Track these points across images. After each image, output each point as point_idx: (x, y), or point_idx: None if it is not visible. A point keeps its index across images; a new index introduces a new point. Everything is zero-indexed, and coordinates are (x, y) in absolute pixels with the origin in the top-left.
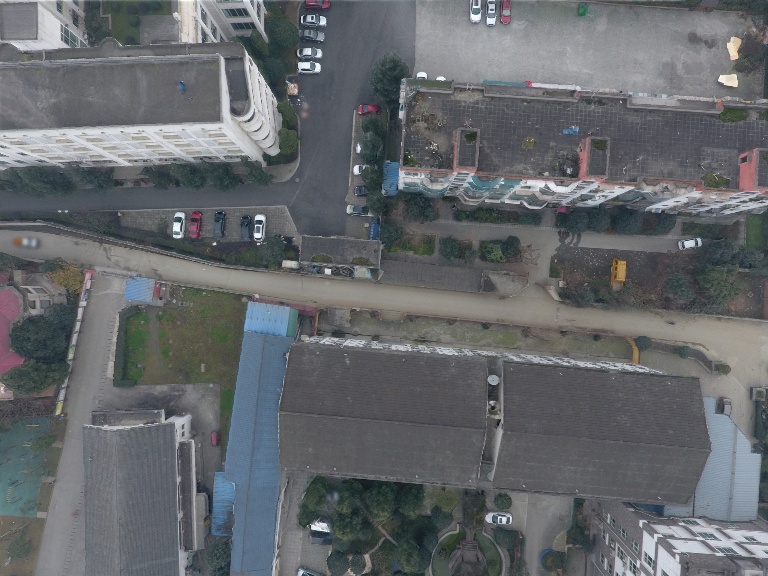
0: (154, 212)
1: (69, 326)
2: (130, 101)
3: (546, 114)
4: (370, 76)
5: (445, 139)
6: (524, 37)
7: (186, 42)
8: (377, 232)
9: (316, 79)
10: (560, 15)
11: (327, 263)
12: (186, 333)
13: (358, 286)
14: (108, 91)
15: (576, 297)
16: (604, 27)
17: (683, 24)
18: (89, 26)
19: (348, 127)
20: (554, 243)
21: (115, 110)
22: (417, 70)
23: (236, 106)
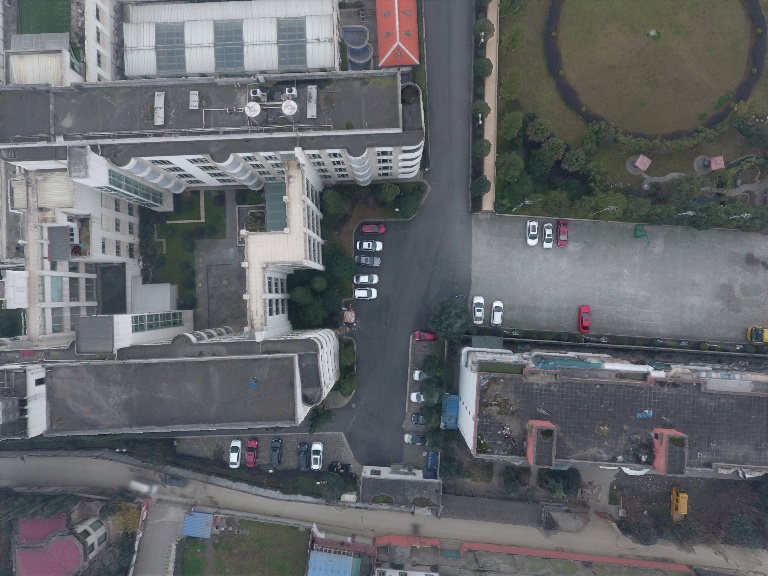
0: (210, 438)
1: (127, 565)
2: (203, 397)
3: (619, 397)
4: (431, 317)
5: (518, 423)
6: (581, 259)
7: (260, 341)
8: (435, 461)
9: (372, 303)
10: (617, 236)
11: (388, 504)
12: (243, 562)
13: (416, 515)
14: (180, 387)
15: (639, 537)
16: (661, 248)
17: (740, 245)
18: (144, 253)
19: (404, 352)
20: (613, 469)
21: (188, 406)
22: (473, 293)
23: (307, 393)
